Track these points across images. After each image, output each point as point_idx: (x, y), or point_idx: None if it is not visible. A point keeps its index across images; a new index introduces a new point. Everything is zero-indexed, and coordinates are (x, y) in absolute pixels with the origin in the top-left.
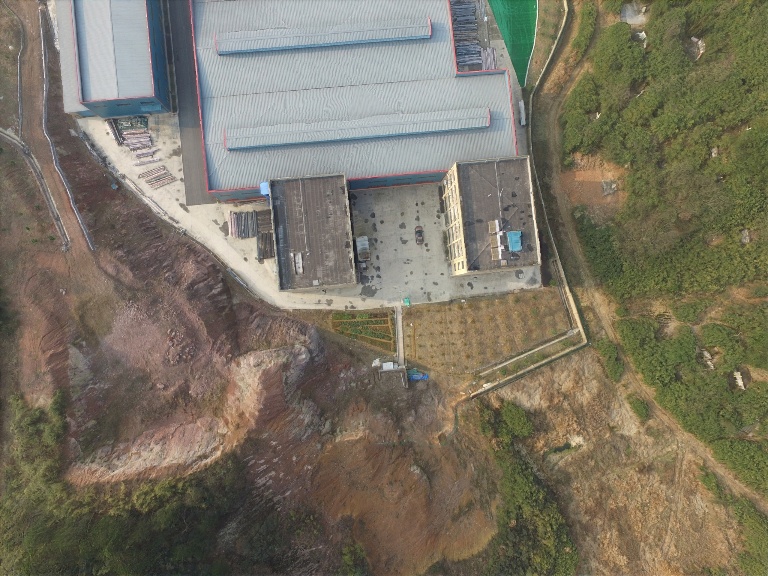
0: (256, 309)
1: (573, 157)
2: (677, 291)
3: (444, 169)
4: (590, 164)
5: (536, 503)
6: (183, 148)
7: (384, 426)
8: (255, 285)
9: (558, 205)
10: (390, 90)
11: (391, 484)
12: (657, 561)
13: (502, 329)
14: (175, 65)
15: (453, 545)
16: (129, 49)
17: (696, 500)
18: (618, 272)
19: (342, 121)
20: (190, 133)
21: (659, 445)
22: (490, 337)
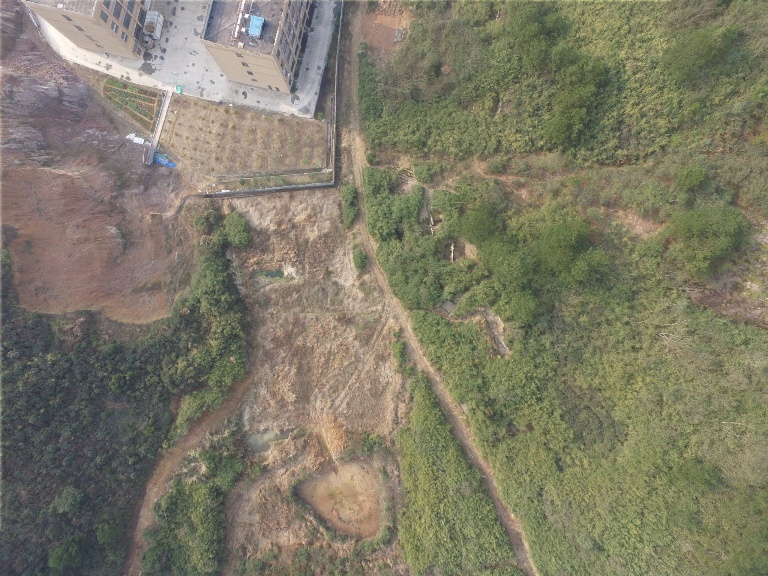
0: (39, 49)
1: None
2: (420, 146)
3: None
4: (391, 9)
5: (217, 303)
6: None
7: (102, 183)
8: (47, 29)
9: (351, 43)
10: None
11: (77, 227)
12: (326, 412)
13: (259, 144)
14: None
15: (121, 310)
16: None
17: (384, 368)
18: (376, 116)
19: None
20: None
21: (367, 302)
22: (245, 148)
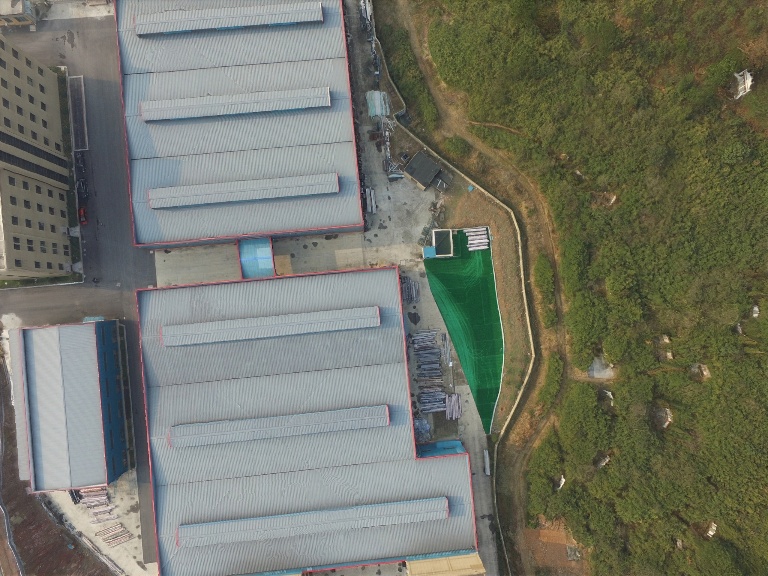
0: None
1: (537, 519)
2: None
3: (402, 554)
4: (554, 527)
5: None
6: (141, 504)
7: None
8: None
9: (522, 562)
10: (348, 474)
11: None
12: None
13: None
14: (133, 418)
15: None
16: (83, 435)
17: None
18: None
19: (298, 513)
20: (148, 488)
21: None
22: None
